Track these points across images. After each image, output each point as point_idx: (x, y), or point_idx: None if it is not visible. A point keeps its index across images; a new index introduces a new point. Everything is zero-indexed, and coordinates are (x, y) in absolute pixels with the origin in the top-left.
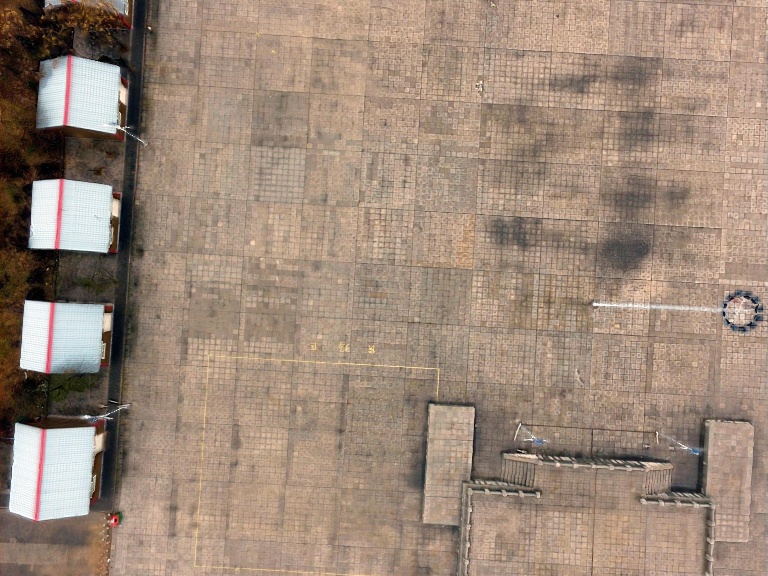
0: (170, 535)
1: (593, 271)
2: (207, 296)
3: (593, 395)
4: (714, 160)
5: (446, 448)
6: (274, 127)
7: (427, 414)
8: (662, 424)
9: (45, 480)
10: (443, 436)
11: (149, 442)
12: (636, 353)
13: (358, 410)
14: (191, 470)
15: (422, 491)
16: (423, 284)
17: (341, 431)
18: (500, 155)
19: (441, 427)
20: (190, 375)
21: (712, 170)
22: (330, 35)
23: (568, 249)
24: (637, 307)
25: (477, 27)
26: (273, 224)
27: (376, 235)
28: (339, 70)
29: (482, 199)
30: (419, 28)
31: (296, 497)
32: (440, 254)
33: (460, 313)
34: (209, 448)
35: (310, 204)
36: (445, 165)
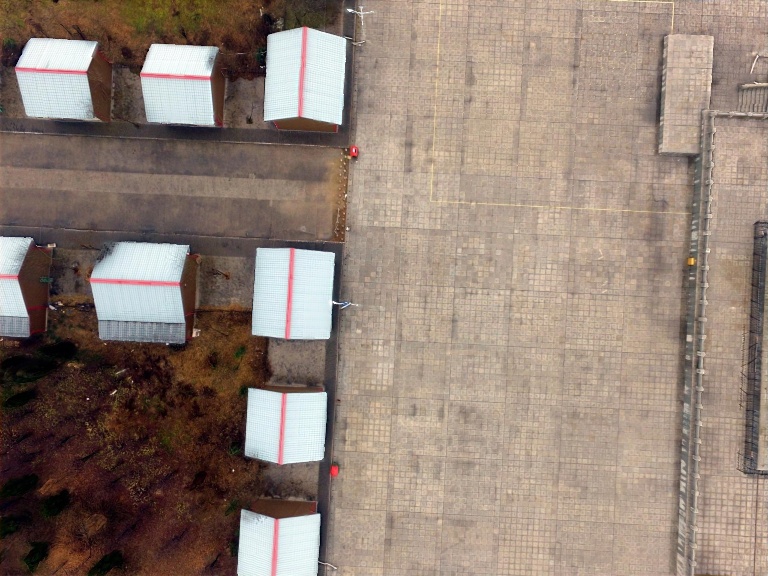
0: (406, 171)
1: None
2: None
3: None
4: None
5: (685, 76)
6: None
7: (662, 48)
8: None
9: (306, 78)
10: (682, 64)
11: (383, 79)
12: None
13: (592, 45)
14: (425, 107)
15: (657, 125)
16: None
17: (575, 67)
18: None
19: (680, 56)
20: (423, 12)
21: None
22: None
23: None
24: None
25: None
26: None
27: None
28: None
29: None
30: None
31: (530, 133)
32: None
33: None
34: (443, 85)
35: None
36: None
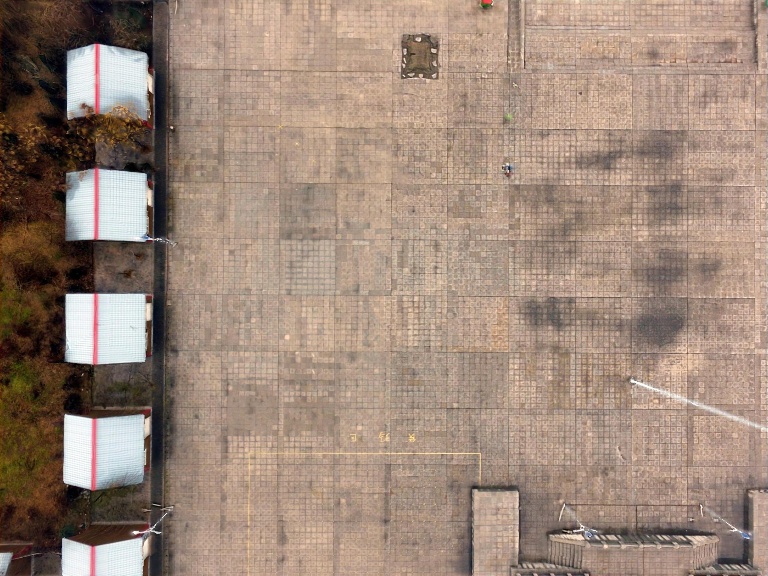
0: None
1: (629, 347)
2: (244, 393)
3: (635, 471)
4: (744, 230)
5: (492, 534)
6: (302, 220)
7: (471, 499)
8: (705, 497)
9: None
10: (488, 522)
11: (194, 543)
12: (676, 427)
13: (402, 499)
14: (238, 569)
15: None
16: (460, 369)
17: (386, 521)
18: (530, 236)
19: (486, 513)
20: (232, 473)
21: (743, 240)
22: (353, 124)
23: (603, 327)
24: (675, 381)
25: (500, 108)
26: (306, 317)
27: (410, 323)
28: (364, 159)
29: (514, 281)
30: (442, 112)
31: None
32: (475, 338)
33: (498, 396)
34: (255, 545)
35: (342, 295)
36: (475, 249)
